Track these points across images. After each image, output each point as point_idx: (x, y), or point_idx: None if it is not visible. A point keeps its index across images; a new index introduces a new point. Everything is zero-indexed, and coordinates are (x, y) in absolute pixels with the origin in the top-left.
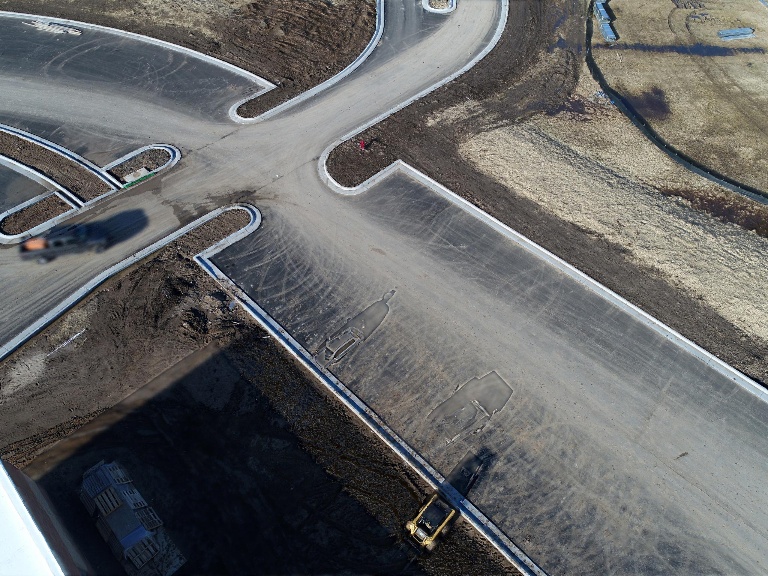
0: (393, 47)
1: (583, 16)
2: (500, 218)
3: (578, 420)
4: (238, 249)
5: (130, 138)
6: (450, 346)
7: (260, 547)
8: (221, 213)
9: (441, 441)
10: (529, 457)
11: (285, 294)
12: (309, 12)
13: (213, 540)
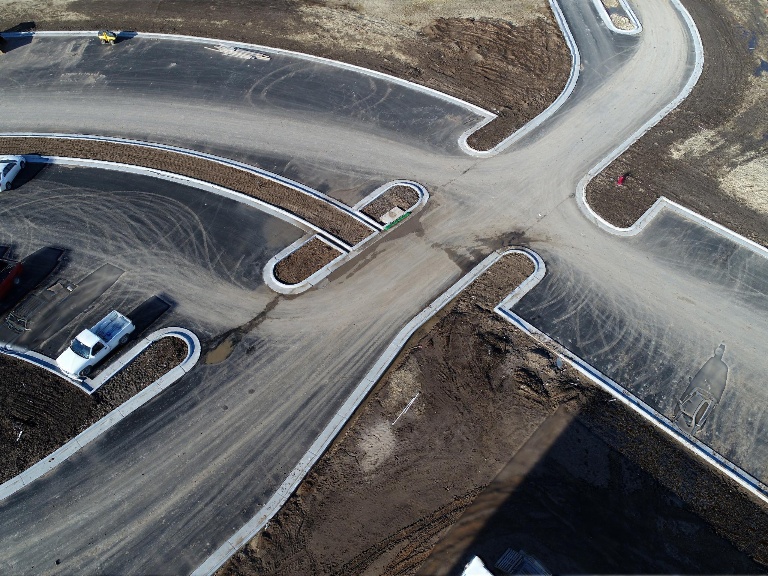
0: (597, 72)
1: None
2: None
3: None
4: (536, 298)
5: (368, 174)
6: None
7: None
8: (500, 258)
9: None
10: None
11: (609, 350)
12: (497, 34)
13: None
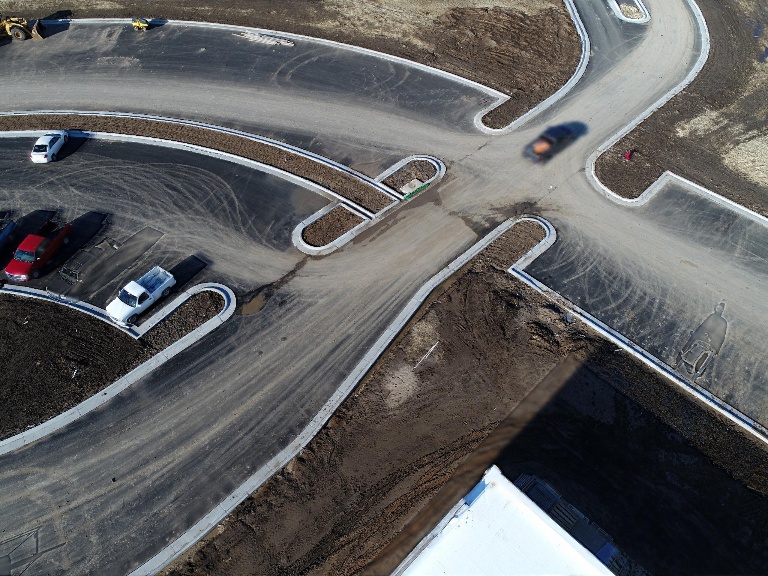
0: (606, 57)
1: None
2: None
3: None
4: (547, 261)
5: (388, 149)
6: None
7: (720, 564)
8: (514, 224)
9: None
10: None
11: (616, 306)
12: (510, 22)
13: (670, 556)
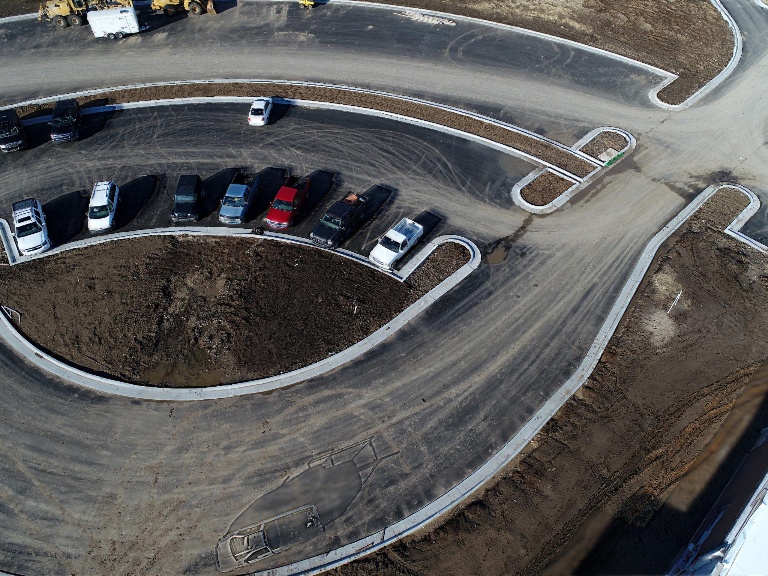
0: (759, 42)
1: None
2: None
3: None
4: (758, 224)
5: (576, 121)
6: None
7: None
8: (717, 191)
9: None
10: None
11: None
12: (658, 8)
13: None
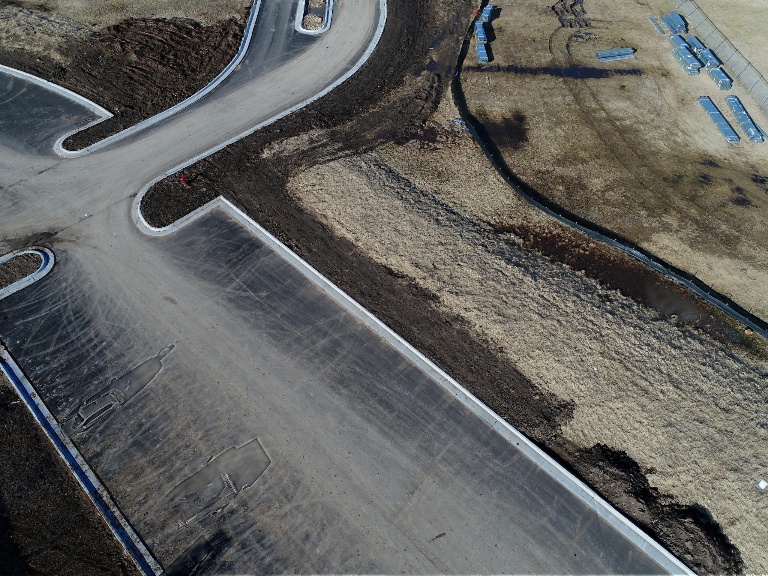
0: (251, 71)
1: (462, 36)
2: (310, 261)
3: (334, 496)
4: (17, 299)
5: None
6: (216, 410)
7: None
8: (11, 258)
9: (173, 524)
10: (267, 542)
11: (52, 351)
12: (171, 34)
13: None
